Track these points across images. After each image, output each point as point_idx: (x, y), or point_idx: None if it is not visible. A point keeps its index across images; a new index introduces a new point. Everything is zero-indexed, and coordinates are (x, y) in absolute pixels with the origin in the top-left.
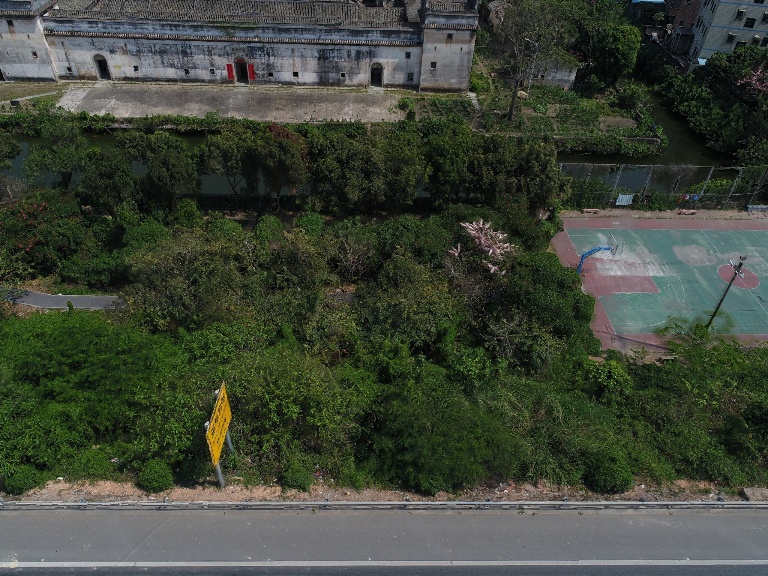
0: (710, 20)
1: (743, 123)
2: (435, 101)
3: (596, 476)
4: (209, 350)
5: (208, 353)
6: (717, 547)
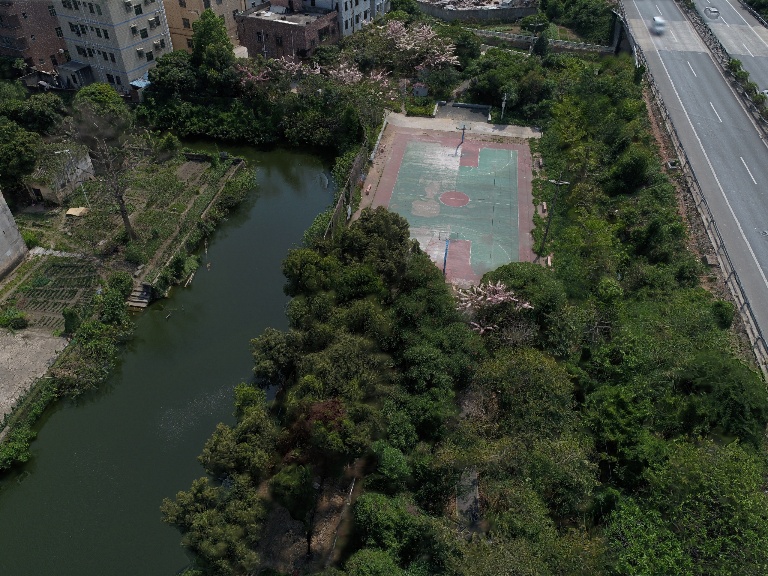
0: (112, 46)
1: (254, 112)
2: (28, 288)
3: (728, 319)
4: (674, 571)
5: (678, 573)
6: (760, 288)
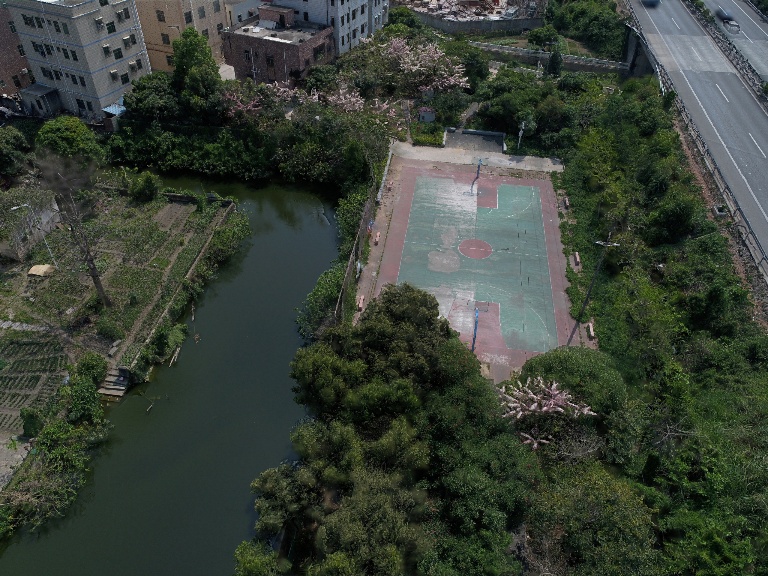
0: (81, 68)
1: (244, 143)
2: None
3: None
4: None
5: None
6: None
